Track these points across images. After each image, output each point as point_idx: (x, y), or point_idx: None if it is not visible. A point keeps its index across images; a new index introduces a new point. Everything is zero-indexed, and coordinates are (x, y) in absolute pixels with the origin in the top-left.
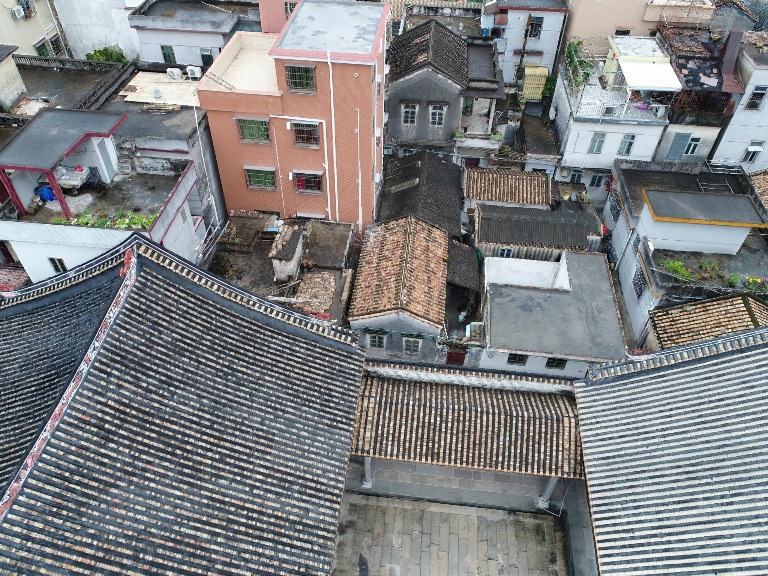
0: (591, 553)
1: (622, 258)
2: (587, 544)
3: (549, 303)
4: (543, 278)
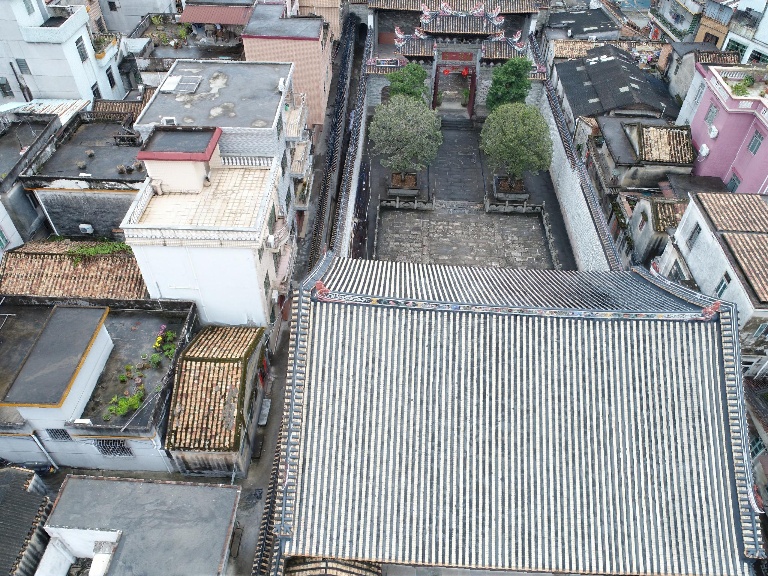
0: (410, 573)
1: (52, 456)
2: (402, 575)
3: (135, 564)
4: (58, 566)
